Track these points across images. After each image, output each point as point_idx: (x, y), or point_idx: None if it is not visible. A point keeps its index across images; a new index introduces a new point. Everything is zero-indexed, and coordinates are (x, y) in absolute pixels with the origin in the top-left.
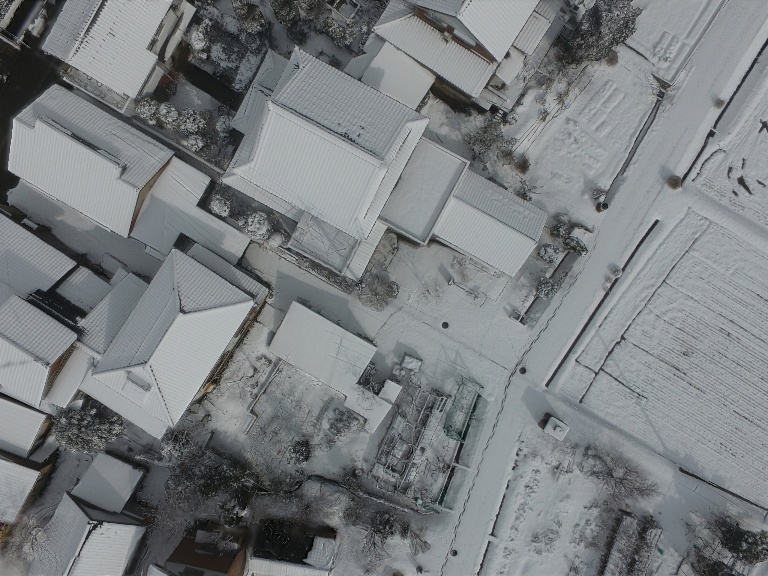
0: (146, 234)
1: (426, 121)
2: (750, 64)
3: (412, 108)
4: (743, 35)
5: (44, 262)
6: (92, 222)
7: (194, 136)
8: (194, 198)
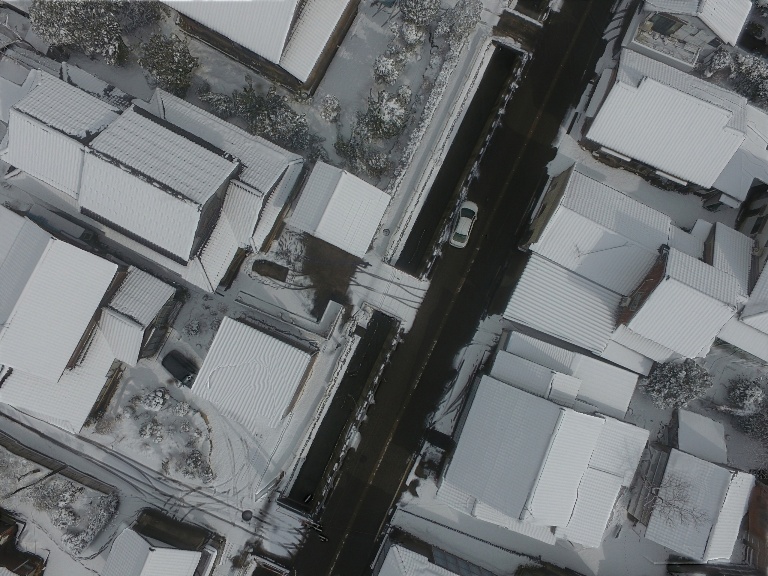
0: (727, 182)
1: None
2: None
3: None
4: None
5: (649, 219)
6: (667, 178)
7: None
8: (763, 142)
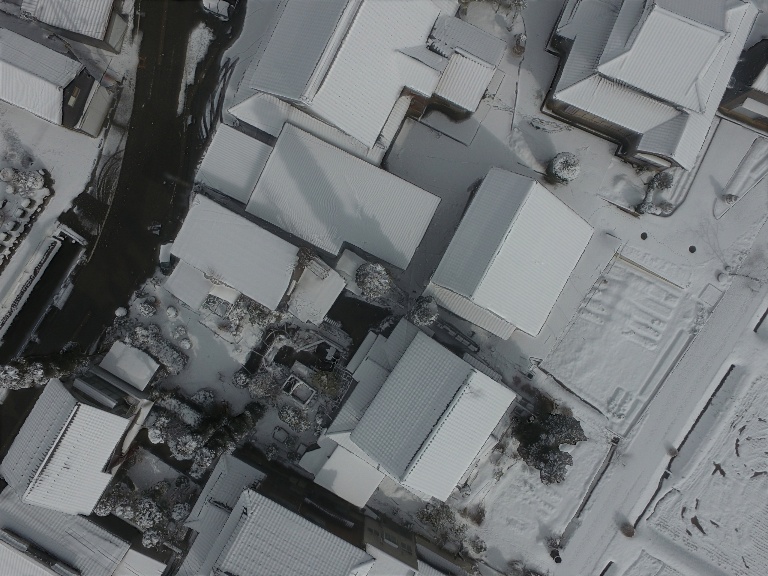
0: None
1: (372, 563)
2: (704, 405)
3: (364, 500)
4: (697, 384)
5: None
6: None
7: (149, 533)
8: None
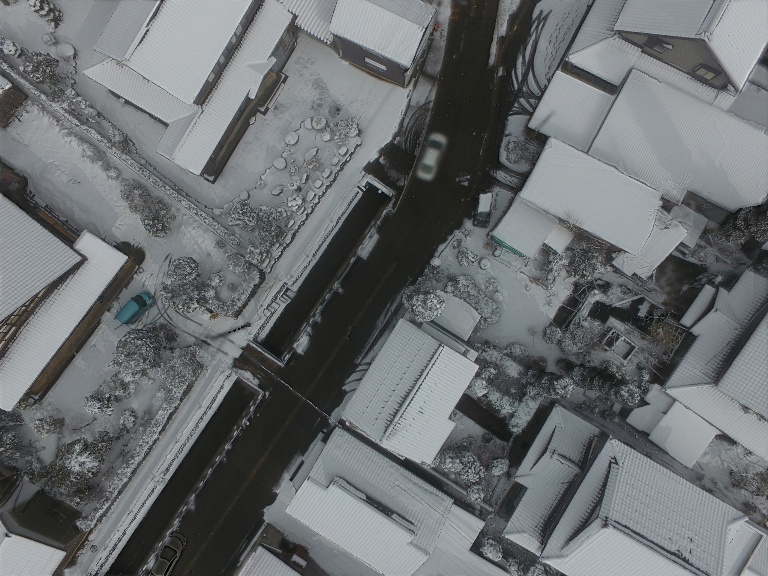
0: None
1: None
2: None
3: (694, 460)
4: None
5: None
6: (364, 563)
7: (476, 487)
8: (468, 542)
